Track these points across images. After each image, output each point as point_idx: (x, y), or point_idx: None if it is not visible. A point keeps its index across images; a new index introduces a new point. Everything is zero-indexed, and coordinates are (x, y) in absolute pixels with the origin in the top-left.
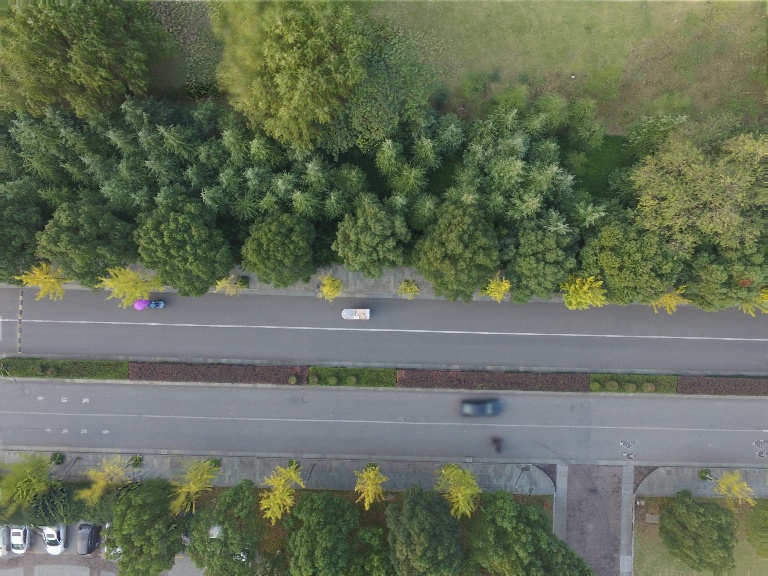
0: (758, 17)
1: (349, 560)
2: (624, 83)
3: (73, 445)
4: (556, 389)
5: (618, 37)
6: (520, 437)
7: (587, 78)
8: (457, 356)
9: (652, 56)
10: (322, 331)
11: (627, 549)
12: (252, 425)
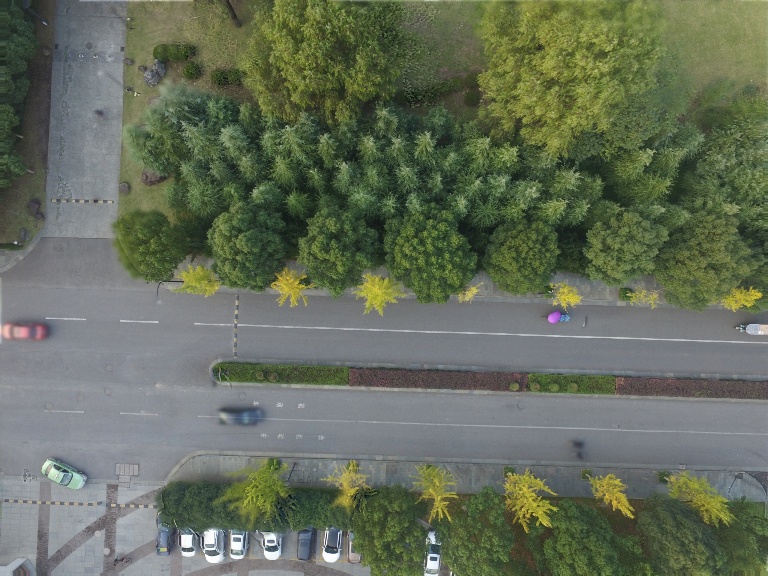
0: None
1: (626, 569)
2: None
3: (288, 450)
4: None
5: None
6: (733, 445)
7: None
8: (671, 364)
9: None
10: (538, 338)
11: None
12: (468, 431)
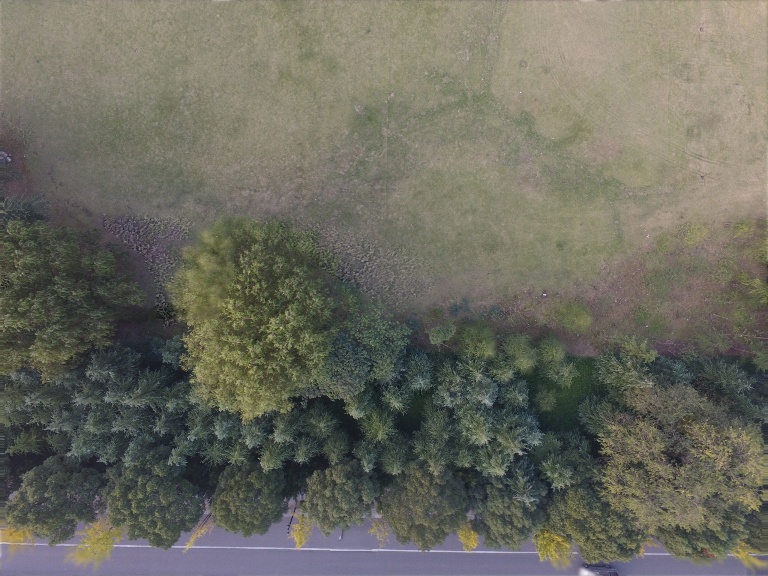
0: (731, 236)
1: None
2: (596, 302)
3: None
4: None
5: (590, 254)
6: None
7: (559, 296)
8: (428, 575)
9: (624, 273)
10: (294, 552)
11: None
12: None
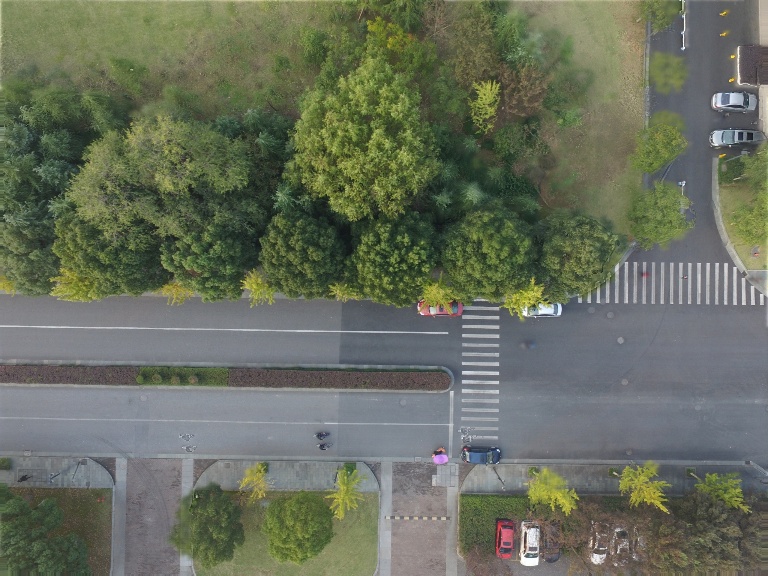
0: (312, 6)
1: None
2: (180, 75)
3: None
4: (105, 382)
5: (177, 29)
6: (78, 431)
7: (146, 71)
8: (14, 350)
9: (210, 47)
10: None
11: (187, 543)
12: None
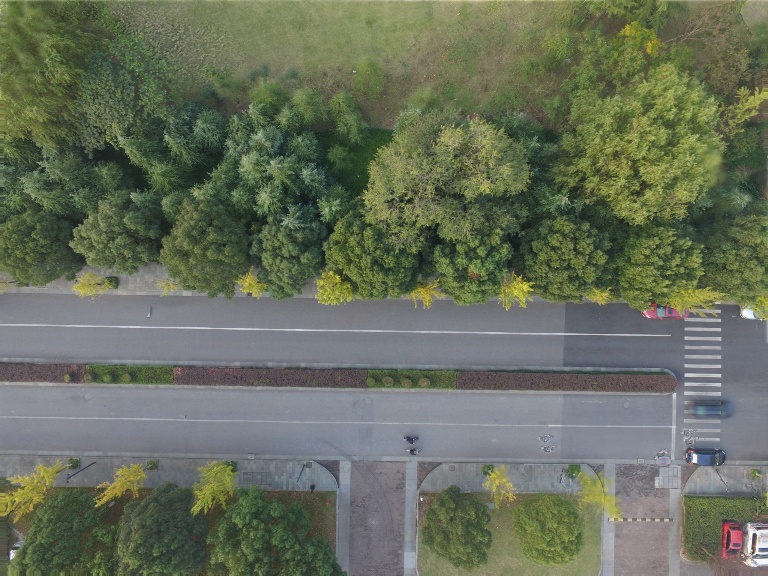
0: (538, 9)
1: (67, 557)
2: (404, 77)
3: None
4: (333, 385)
5: (400, 31)
6: (302, 434)
7: (368, 73)
8: (238, 353)
9: (433, 50)
10: (102, 329)
11: (411, 545)
12: (34, 423)
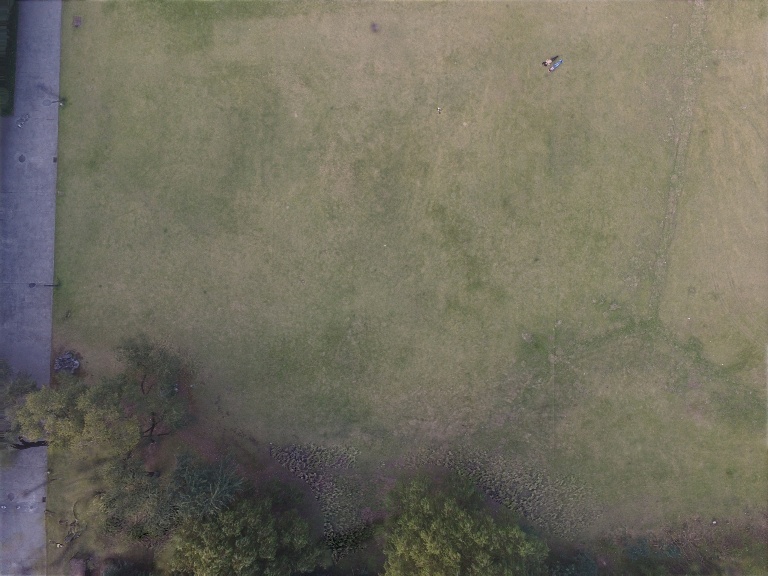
0: None
1: None
2: (767, 531)
3: None
4: None
5: (760, 481)
6: None
7: (728, 523)
8: None
9: None
10: None
11: None
12: None
